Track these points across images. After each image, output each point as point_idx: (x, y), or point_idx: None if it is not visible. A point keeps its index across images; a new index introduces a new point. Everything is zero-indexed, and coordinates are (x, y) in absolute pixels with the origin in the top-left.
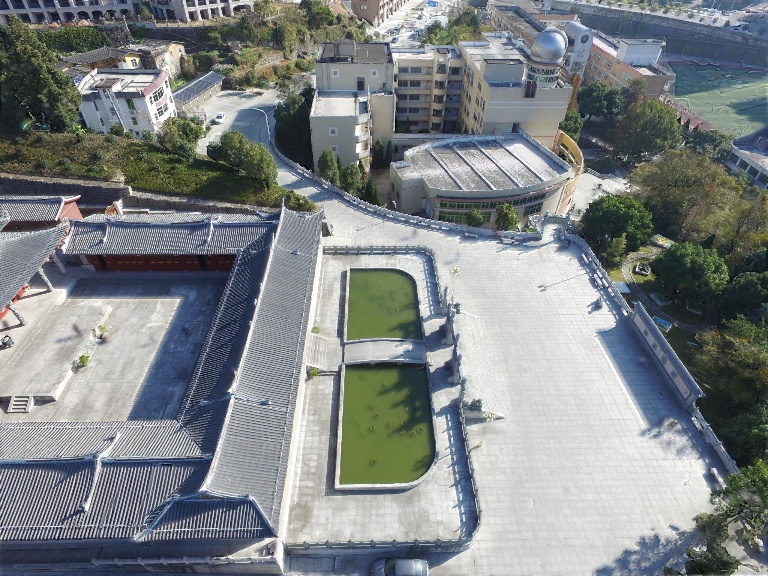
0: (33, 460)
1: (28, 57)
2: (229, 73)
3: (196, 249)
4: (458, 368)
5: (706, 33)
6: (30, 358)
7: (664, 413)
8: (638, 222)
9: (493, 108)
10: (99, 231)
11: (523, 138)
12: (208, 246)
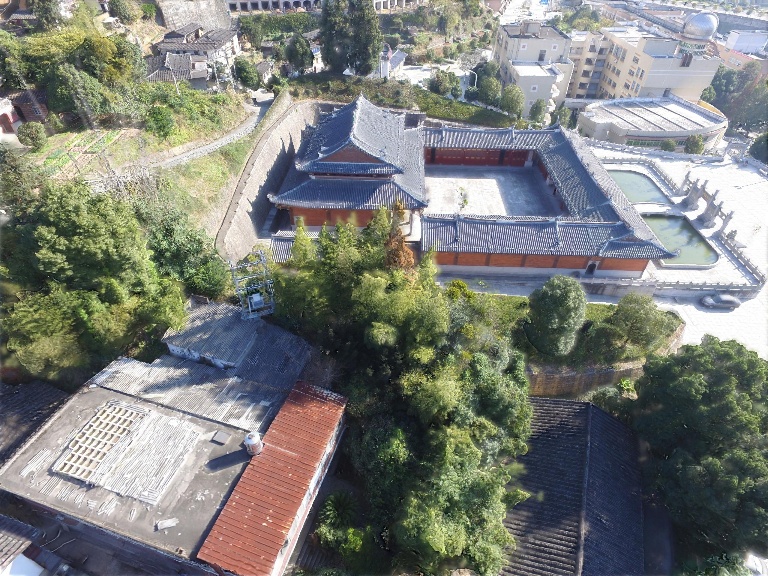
0: (520, 221)
1: (367, 20)
2: (410, 51)
3: (507, 146)
4: (718, 212)
5: None
6: (430, 201)
7: None
8: None
9: (653, 75)
10: (437, 133)
11: (674, 101)
12: (514, 144)
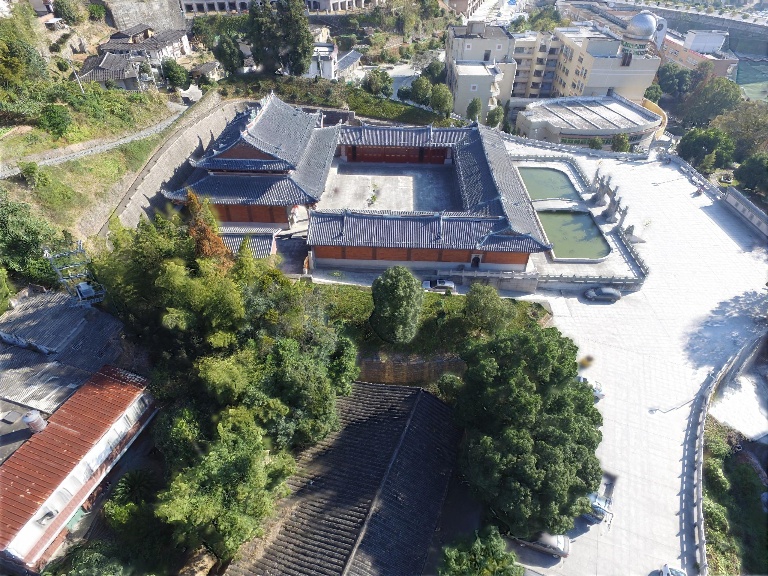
0: (406, 215)
1: (295, 20)
2: (366, 52)
3: (424, 143)
4: (617, 208)
5: (760, 32)
6: (339, 197)
7: (753, 244)
8: (724, 145)
9: (594, 75)
10: (357, 132)
11: (617, 100)
12: (431, 142)
